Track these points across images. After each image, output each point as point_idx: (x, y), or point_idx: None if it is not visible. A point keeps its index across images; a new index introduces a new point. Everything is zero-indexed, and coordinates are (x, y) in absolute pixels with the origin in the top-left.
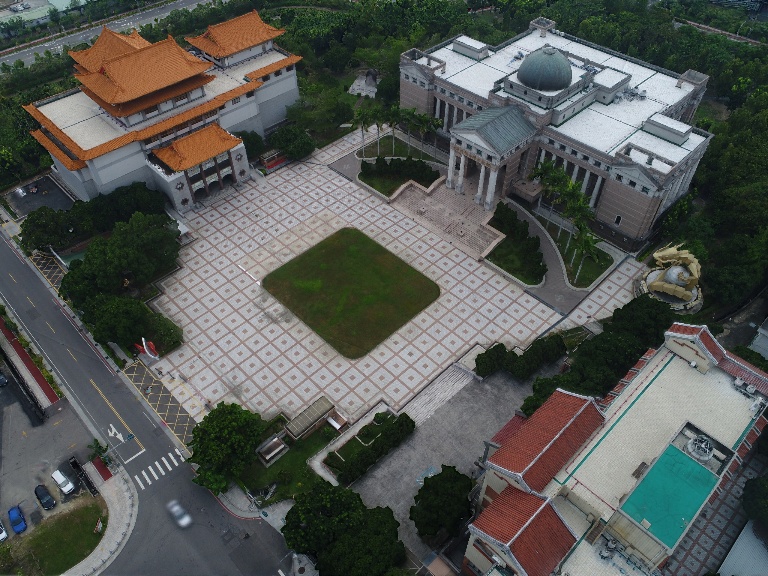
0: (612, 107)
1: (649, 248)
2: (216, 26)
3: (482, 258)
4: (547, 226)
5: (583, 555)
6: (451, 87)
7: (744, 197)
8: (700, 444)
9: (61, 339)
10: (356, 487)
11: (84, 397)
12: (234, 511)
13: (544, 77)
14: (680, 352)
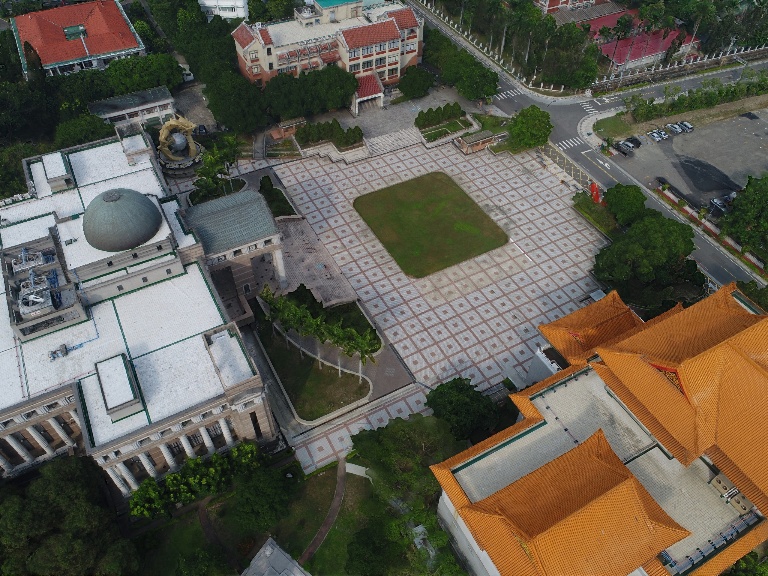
0: None
1: None
2: (617, 487)
3: None
4: None
5: None
6: None
7: None
8: None
9: None
10: None
11: None
12: None
13: None
14: None
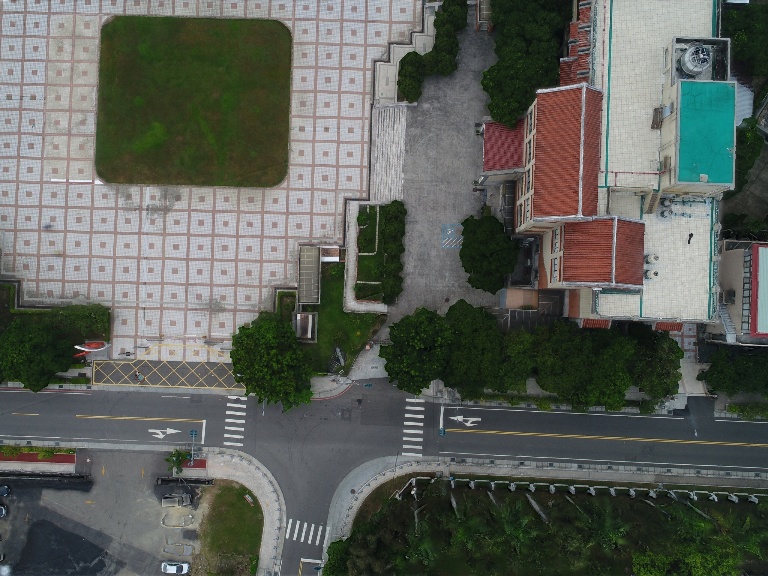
0: None
1: None
2: None
3: None
4: None
5: (650, 227)
6: None
7: None
8: (699, 57)
9: None
10: (402, 295)
11: (93, 433)
12: (330, 395)
13: None
14: None
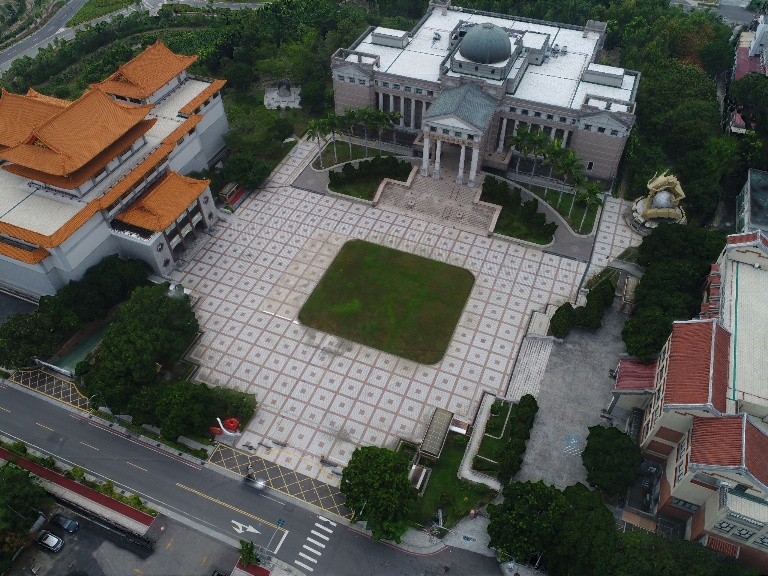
0: (546, 66)
1: (617, 184)
2: (126, 65)
3: (491, 233)
4: None
5: None
6: (395, 79)
7: (676, 120)
8: None
9: (112, 454)
10: (517, 480)
11: (182, 505)
12: (418, 551)
13: (492, 50)
14: (742, 259)
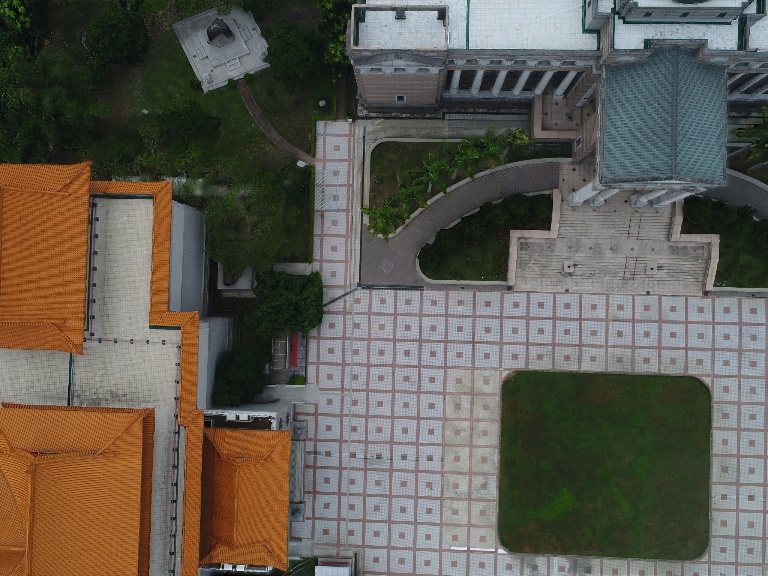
0: None
1: None
2: None
3: None
4: (750, 169)
5: None
6: (496, 56)
7: None
8: None
9: None
10: None
11: None
12: None
13: None
14: None
